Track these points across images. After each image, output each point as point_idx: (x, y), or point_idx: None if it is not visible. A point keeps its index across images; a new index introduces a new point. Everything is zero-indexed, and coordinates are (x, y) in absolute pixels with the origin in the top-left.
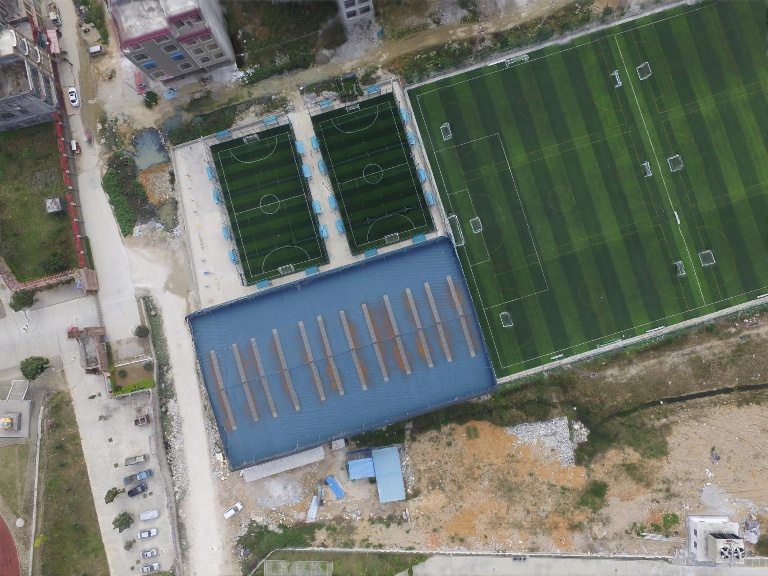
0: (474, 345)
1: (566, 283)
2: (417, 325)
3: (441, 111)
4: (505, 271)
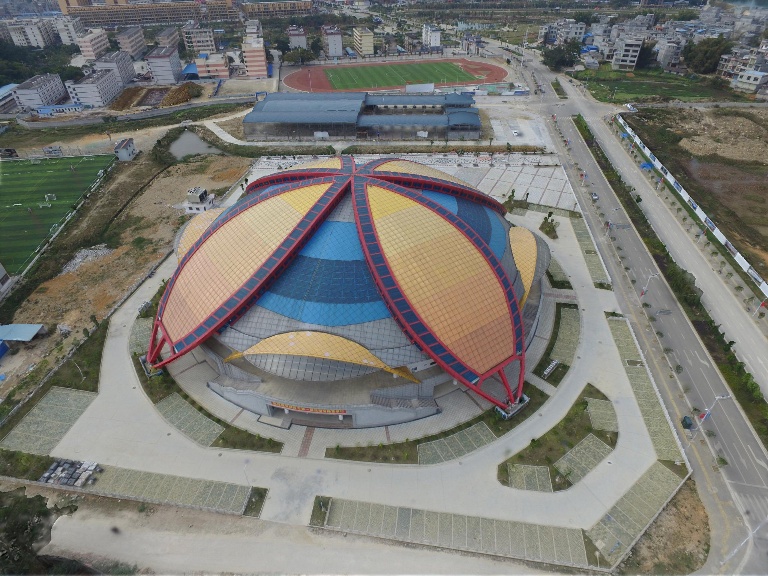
0: None
1: None
2: None
3: None
4: None
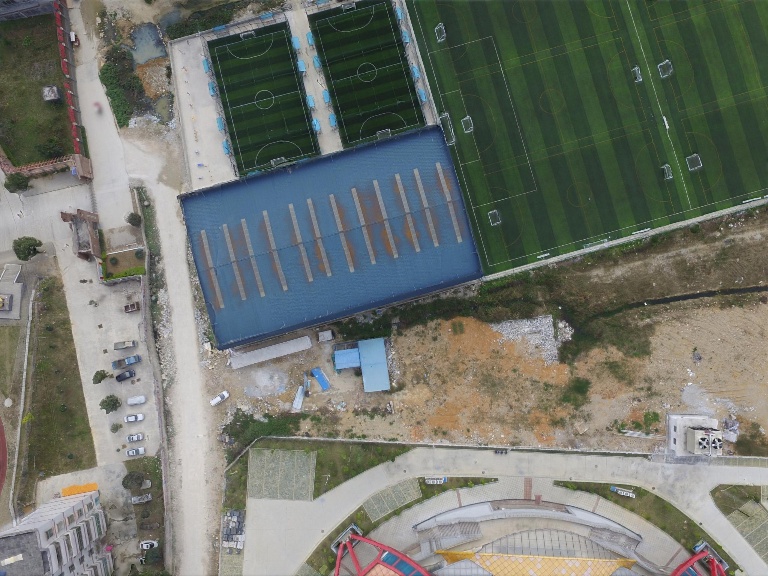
0: (461, 231)
1: (554, 184)
2: (405, 210)
3: (436, 13)
4: (495, 171)
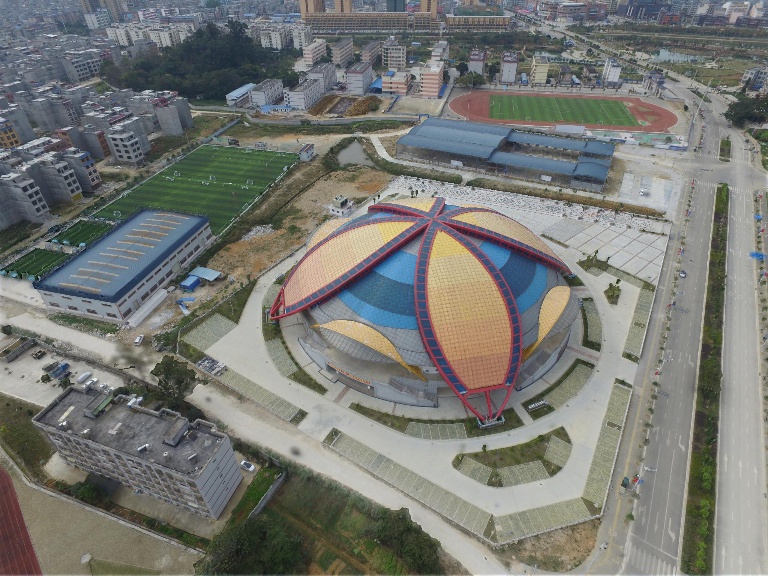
0: (185, 217)
1: None
2: None
3: None
4: None
